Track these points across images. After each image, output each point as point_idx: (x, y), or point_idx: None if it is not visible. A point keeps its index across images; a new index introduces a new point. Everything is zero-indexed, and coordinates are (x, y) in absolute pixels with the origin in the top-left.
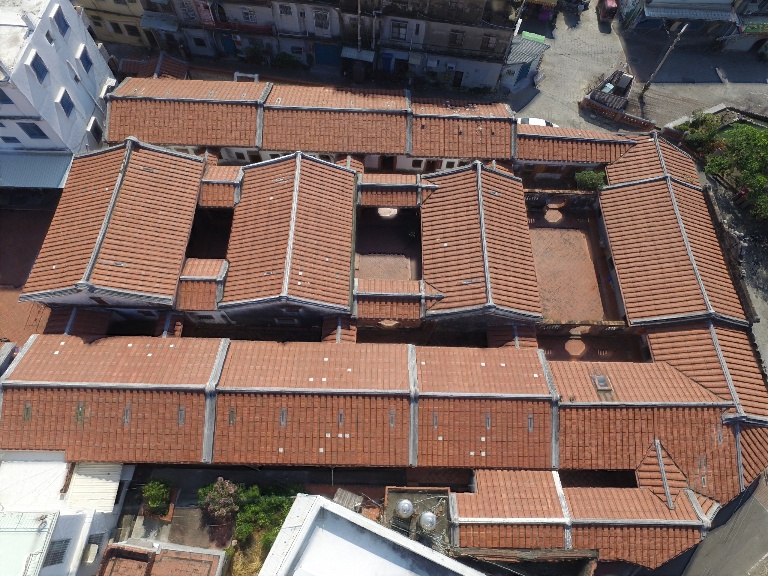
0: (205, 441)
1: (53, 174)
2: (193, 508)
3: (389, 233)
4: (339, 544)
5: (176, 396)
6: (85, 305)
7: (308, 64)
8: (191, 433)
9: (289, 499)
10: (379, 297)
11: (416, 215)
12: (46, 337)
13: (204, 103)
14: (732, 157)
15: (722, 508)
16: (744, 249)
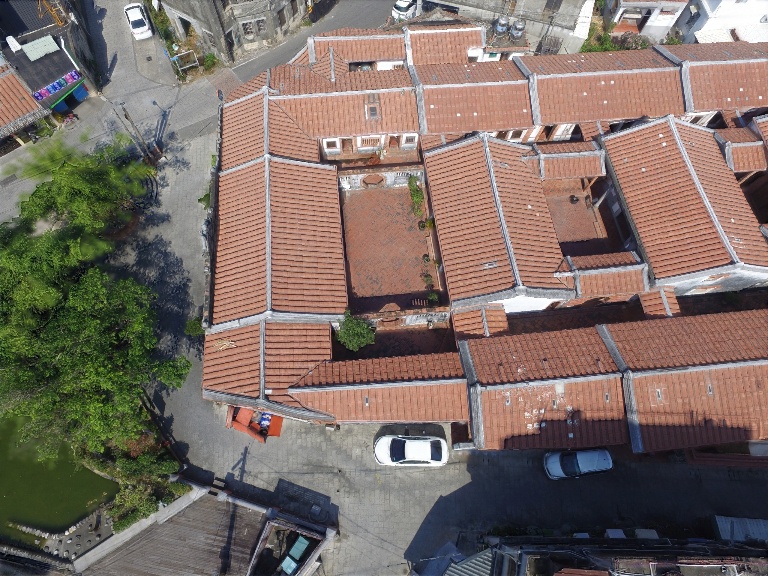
0: None
1: None
2: None
3: None
4: None
5: None
6: None
7: None
8: None
9: None
10: None
11: None
12: None
13: None
14: None
15: None
16: None
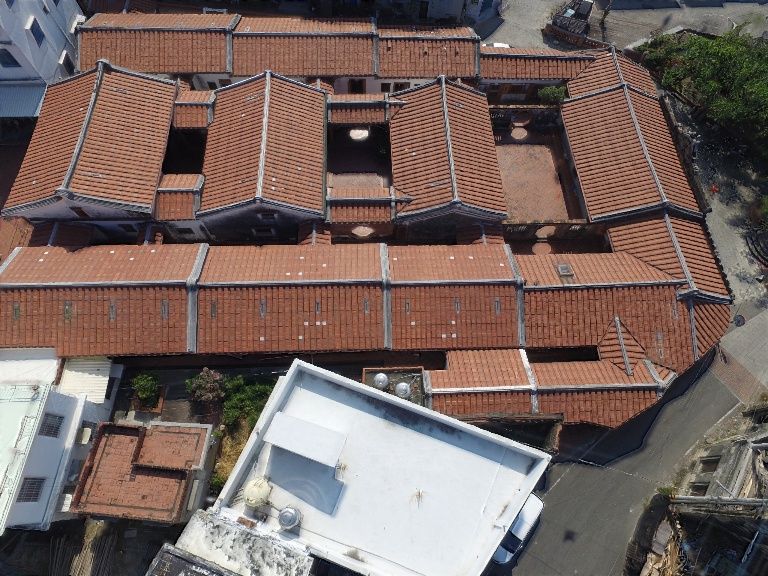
0: (189, 332)
1: (28, 104)
2: (181, 401)
3: (361, 154)
4: (317, 400)
5: (159, 292)
6: (66, 219)
7: (276, 1)
8: (175, 326)
9: (272, 387)
10: (351, 202)
11: (386, 135)
12: (30, 248)
13: (174, 32)
14: (686, 67)
15: (680, 382)
16: (696, 146)
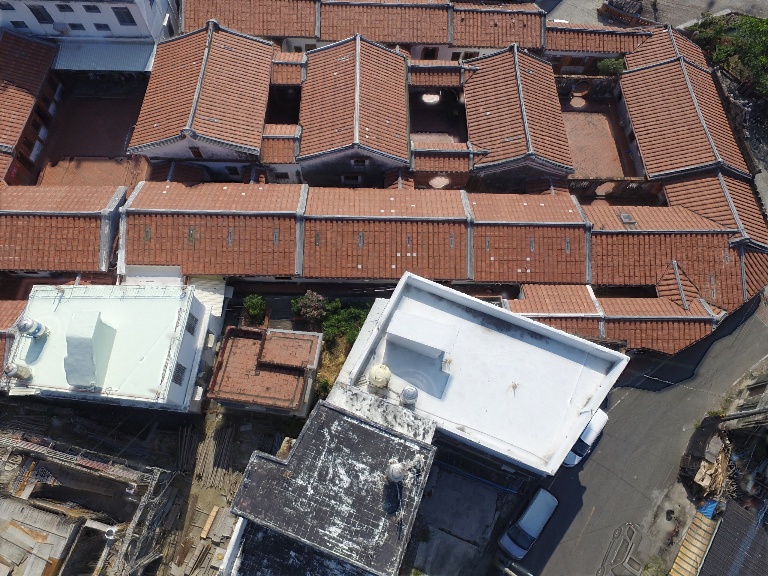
0: (297, 257)
1: (139, 60)
2: (284, 321)
3: (433, 116)
4: (423, 308)
5: (271, 221)
6: (182, 159)
7: None
8: (285, 251)
9: (365, 311)
10: (433, 153)
11: (457, 100)
12: (152, 183)
13: None
14: (737, 43)
15: (728, 323)
16: (748, 114)
